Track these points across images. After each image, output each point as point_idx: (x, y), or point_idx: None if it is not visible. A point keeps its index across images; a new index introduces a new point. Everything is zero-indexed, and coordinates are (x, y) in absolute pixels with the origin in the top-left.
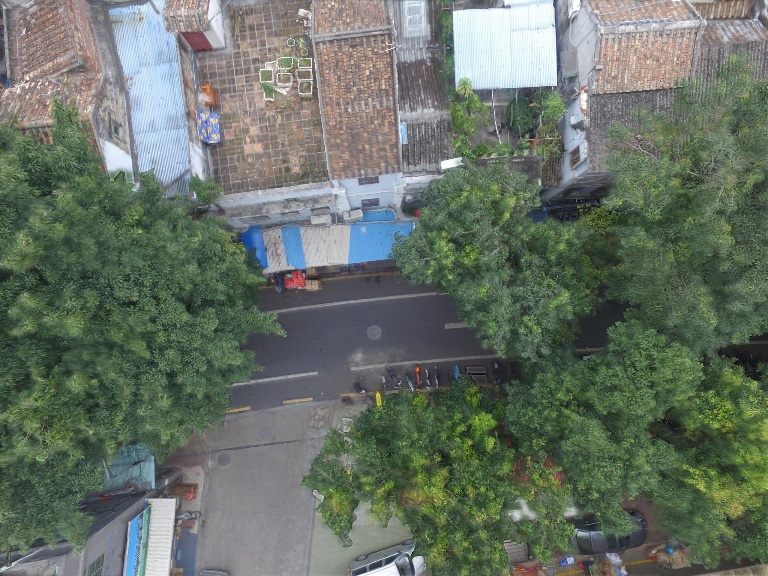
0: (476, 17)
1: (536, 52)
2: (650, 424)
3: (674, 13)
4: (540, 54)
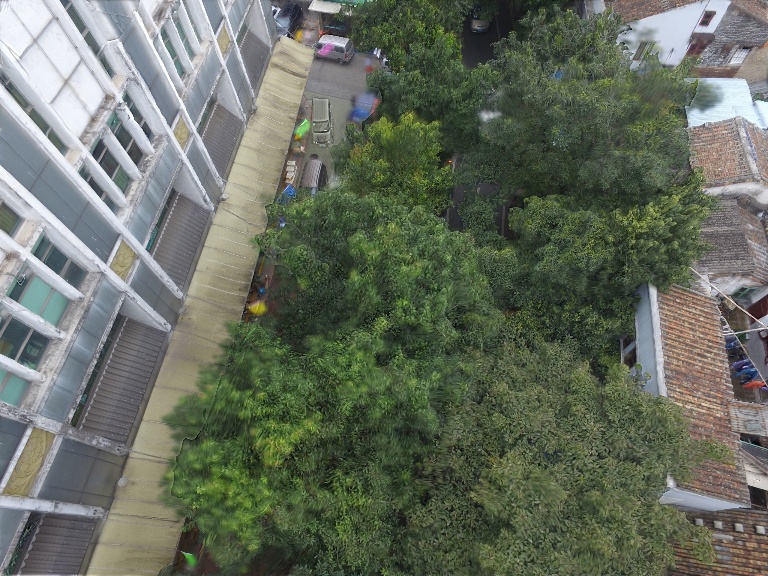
0: (742, 89)
1: (717, 118)
2: (431, 100)
3: (765, 174)
4: (716, 120)
